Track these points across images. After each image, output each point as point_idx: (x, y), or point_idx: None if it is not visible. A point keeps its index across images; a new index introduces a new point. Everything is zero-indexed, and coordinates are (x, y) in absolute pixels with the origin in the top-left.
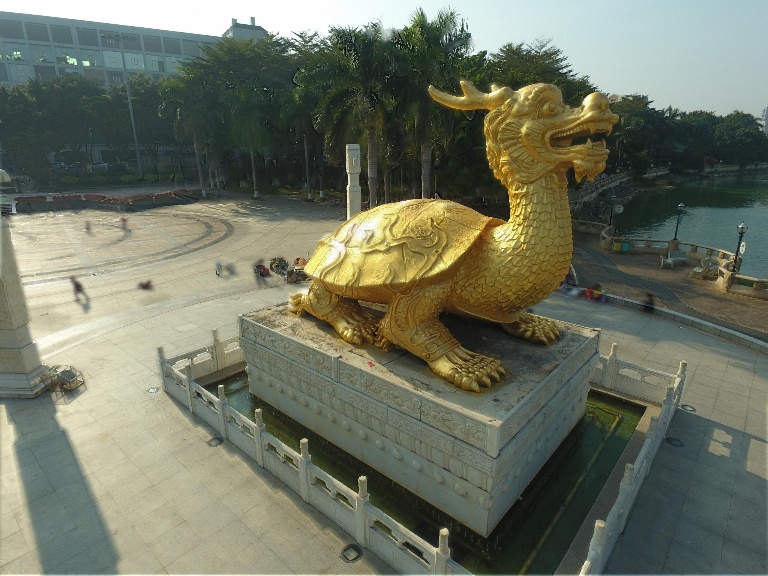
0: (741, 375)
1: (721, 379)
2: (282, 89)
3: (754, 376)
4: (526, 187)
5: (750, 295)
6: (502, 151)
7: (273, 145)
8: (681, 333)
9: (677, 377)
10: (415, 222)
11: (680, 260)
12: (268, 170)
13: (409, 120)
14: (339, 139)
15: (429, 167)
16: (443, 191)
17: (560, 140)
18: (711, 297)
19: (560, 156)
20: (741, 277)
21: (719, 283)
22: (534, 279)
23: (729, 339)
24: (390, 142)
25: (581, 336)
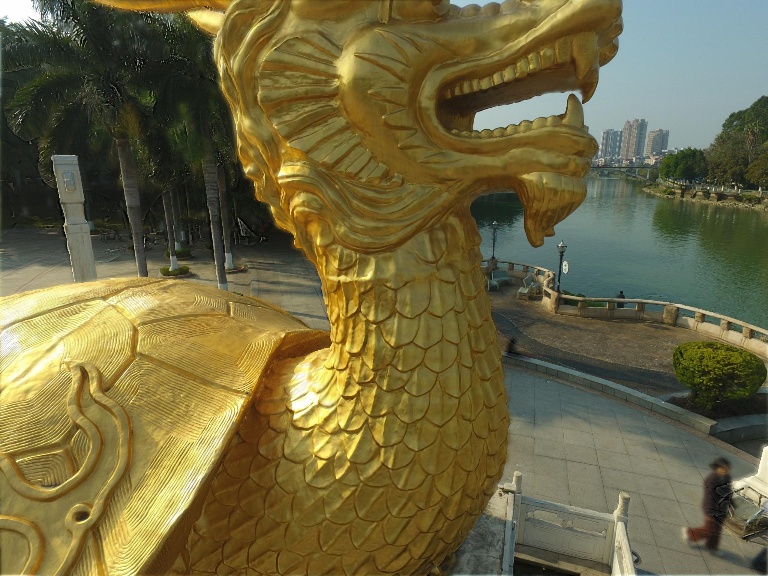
0: (646, 456)
1: (632, 471)
2: (12, 88)
3: (659, 454)
4: (373, 264)
5: (576, 315)
6: (280, 144)
7: (6, 163)
8: (552, 392)
9: (617, 520)
10: (19, 388)
11: (503, 280)
12: (3, 196)
13: (177, 125)
14: (66, 150)
15: (216, 190)
16: (248, 217)
17: (455, 113)
18: (545, 322)
19: (475, 159)
20: (567, 297)
21: (546, 304)
22: (427, 547)
23: (602, 391)
24: (153, 156)
25: (491, 519)
